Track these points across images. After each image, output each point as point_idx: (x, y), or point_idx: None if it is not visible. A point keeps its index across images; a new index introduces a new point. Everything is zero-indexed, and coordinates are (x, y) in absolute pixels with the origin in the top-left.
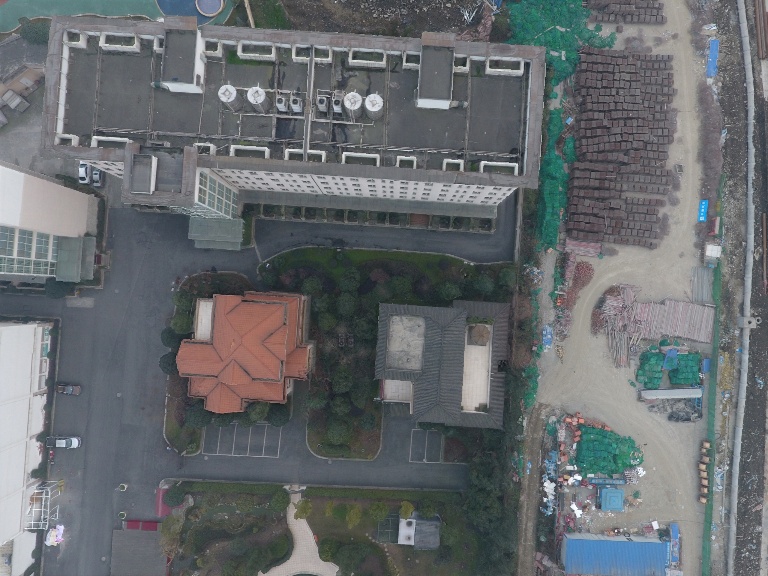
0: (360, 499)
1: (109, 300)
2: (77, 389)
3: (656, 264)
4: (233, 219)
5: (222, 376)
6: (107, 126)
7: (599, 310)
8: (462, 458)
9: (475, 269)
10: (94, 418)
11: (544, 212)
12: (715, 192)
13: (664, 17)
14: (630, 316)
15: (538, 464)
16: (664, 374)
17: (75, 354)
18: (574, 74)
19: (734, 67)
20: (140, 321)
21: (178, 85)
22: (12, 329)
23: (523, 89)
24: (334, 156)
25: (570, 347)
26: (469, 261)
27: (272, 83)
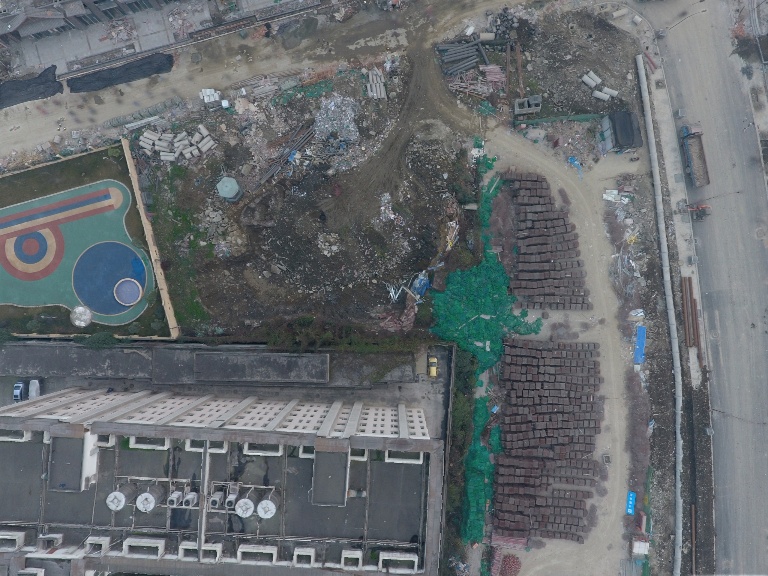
0: None
1: None
2: None
3: (584, 556)
4: None
5: None
6: None
7: None
8: None
9: None
10: None
11: (468, 511)
12: (642, 486)
13: (590, 305)
14: None
15: None
16: None
17: None
18: (500, 361)
19: (662, 353)
20: None
21: None
22: None
23: (423, 477)
24: (231, 545)
25: None
26: None
27: (167, 470)
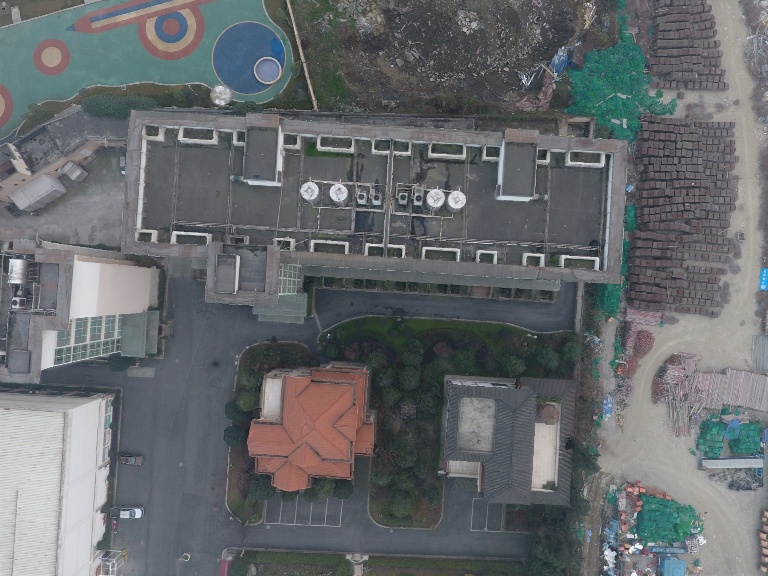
0: (422, 568)
1: (170, 370)
2: (140, 459)
3: (717, 332)
4: (297, 294)
5: (293, 457)
6: (185, 219)
7: (660, 379)
8: (525, 529)
9: (536, 338)
10: (156, 488)
11: None
12: None
13: (726, 84)
14: (691, 386)
15: (598, 532)
16: (724, 443)
17: (137, 424)
18: (635, 141)
19: None
20: (201, 391)
21: (259, 182)
22: (81, 408)
23: (603, 181)
24: (413, 249)
25: (630, 416)
26: (529, 330)
27: (350, 175)
